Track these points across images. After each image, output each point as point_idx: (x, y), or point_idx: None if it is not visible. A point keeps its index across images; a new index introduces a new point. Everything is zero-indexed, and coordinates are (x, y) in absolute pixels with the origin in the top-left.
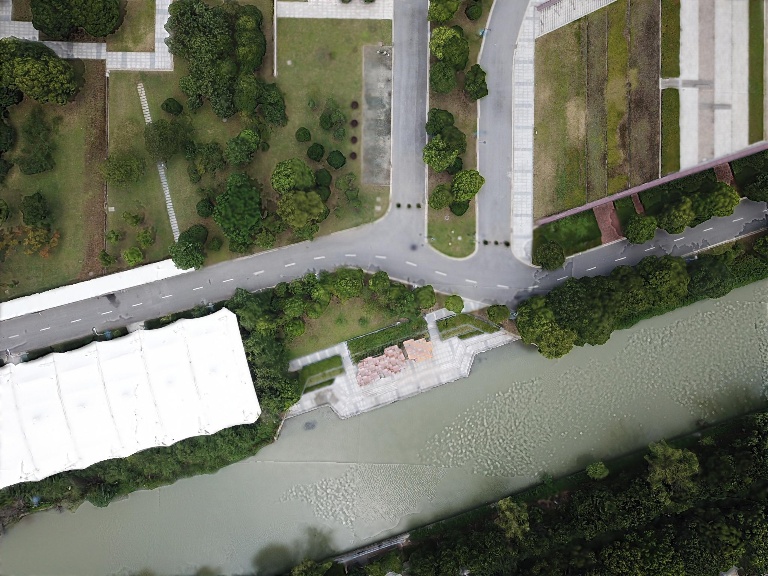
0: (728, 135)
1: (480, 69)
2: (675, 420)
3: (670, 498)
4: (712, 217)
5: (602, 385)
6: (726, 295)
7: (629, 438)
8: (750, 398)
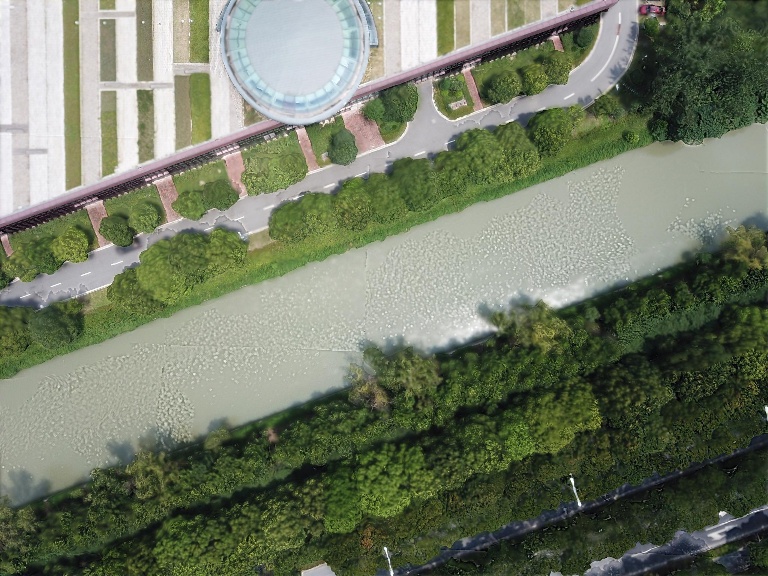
0: (44, 181)
1: None
2: (71, 470)
3: (4, 557)
4: (90, 261)
5: (1, 435)
6: (142, 338)
7: (19, 490)
8: (145, 446)
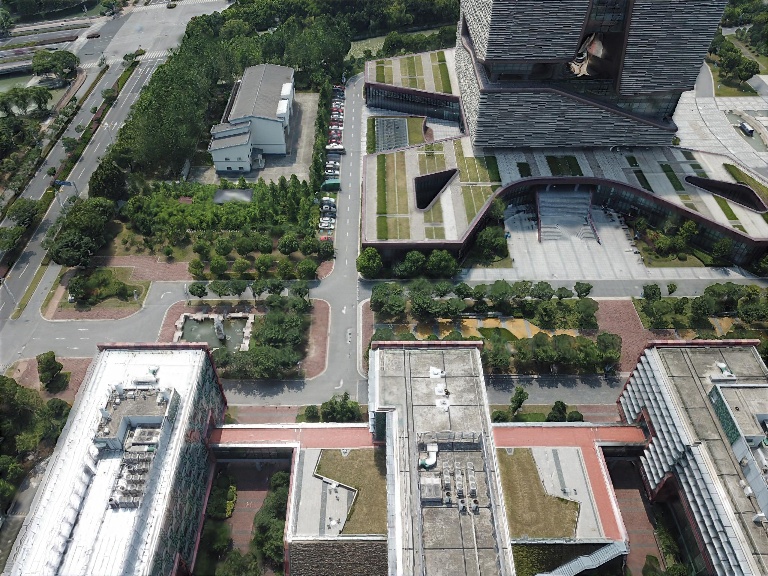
0: None
1: (716, 40)
2: None
3: None
4: None
5: None
6: None
7: None
8: None
